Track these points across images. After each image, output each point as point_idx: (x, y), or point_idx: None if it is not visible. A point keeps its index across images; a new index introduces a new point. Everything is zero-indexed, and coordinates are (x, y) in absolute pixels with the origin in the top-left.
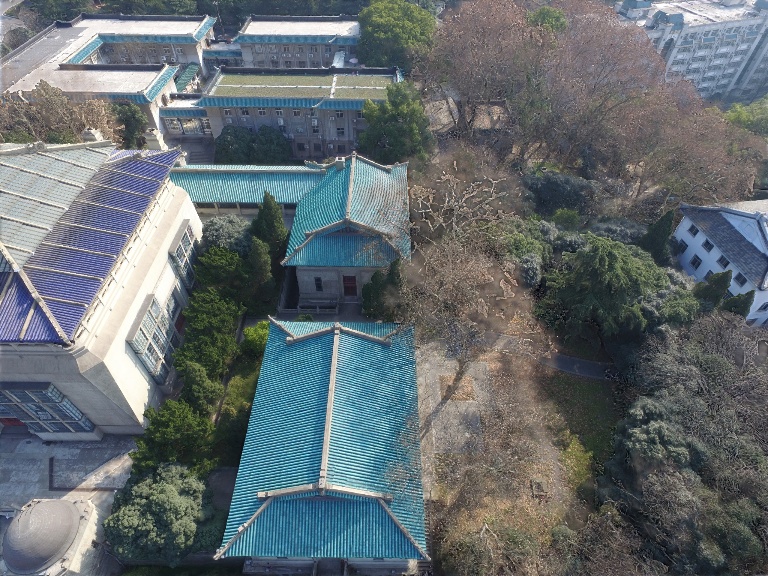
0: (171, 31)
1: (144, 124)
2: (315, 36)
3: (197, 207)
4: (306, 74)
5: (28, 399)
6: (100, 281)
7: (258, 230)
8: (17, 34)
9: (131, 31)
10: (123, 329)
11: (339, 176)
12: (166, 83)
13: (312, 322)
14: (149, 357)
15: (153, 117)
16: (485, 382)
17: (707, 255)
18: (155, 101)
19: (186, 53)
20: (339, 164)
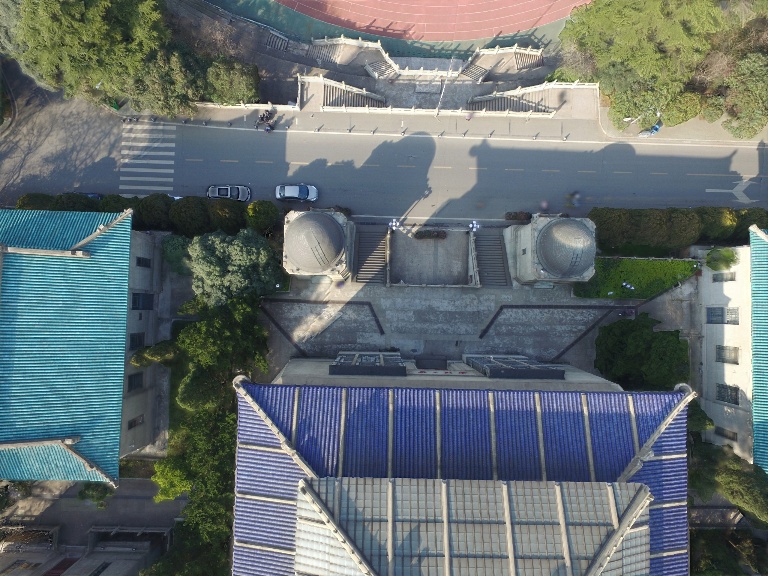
0: None
1: None
2: None
3: None
4: None
5: None
6: (238, 491)
7: None
8: None
9: None
10: None
11: None
12: None
13: None
14: None
15: None
16: None
17: None
18: None
19: None
20: None
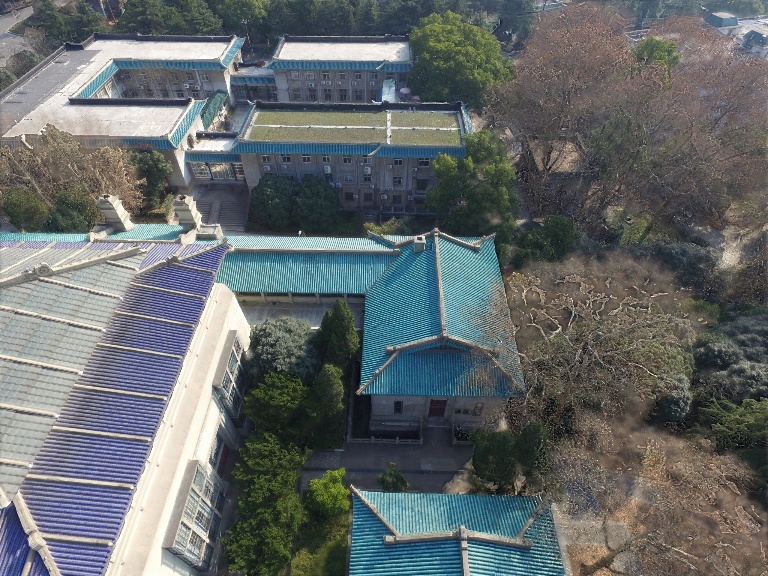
0: (195, 55)
1: (168, 174)
2: (360, 62)
3: (238, 294)
4: (354, 110)
5: None
6: (129, 490)
7: (324, 342)
8: (22, 58)
9: (150, 55)
10: (159, 534)
11: (419, 261)
12: (193, 122)
13: (410, 494)
14: (191, 550)
15: (178, 163)
16: (629, 557)
17: None
18: (180, 144)
19: (212, 80)
20: (419, 245)
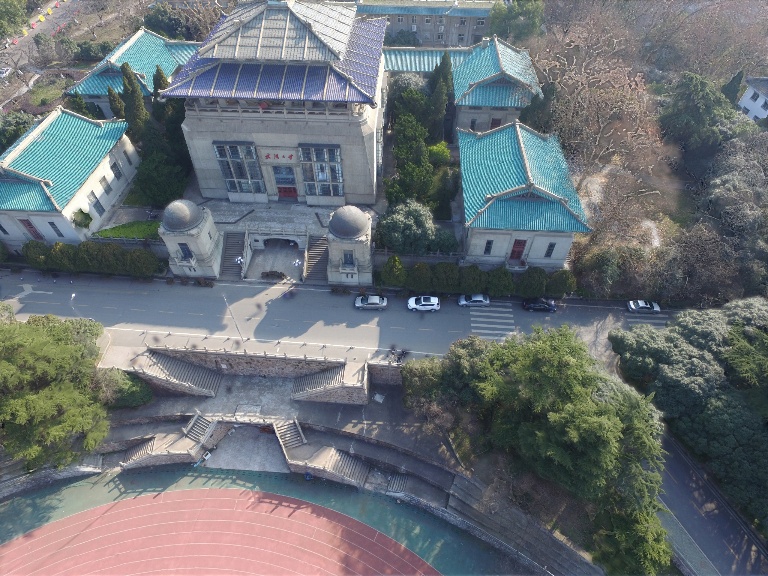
0: None
1: None
2: None
3: None
4: None
5: (322, 158)
6: (376, 79)
7: (434, 82)
8: None
9: None
10: None
11: (485, 51)
12: None
13: None
14: None
15: None
16: (599, 188)
17: (765, 113)
18: None
19: None
20: (485, 43)
